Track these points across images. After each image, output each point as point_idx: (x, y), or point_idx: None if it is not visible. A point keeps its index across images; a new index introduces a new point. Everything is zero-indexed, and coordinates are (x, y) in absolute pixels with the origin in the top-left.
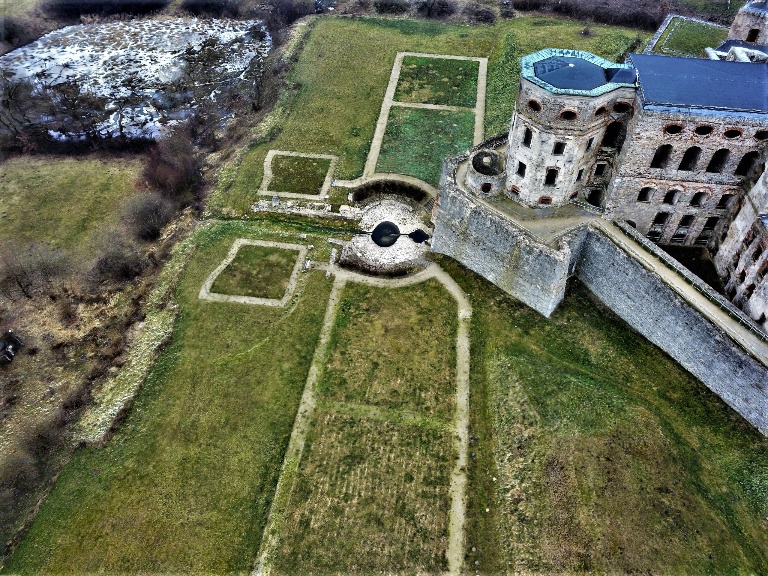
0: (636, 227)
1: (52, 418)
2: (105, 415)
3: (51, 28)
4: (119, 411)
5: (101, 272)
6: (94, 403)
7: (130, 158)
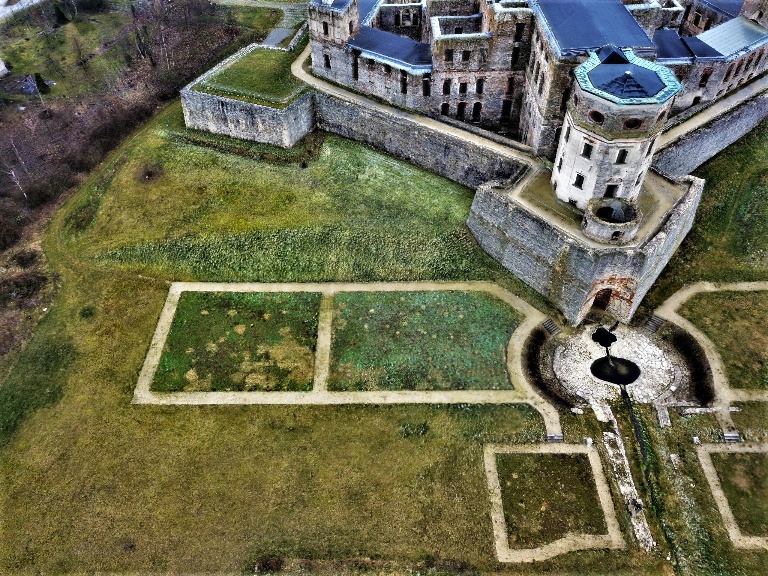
0: None
1: None
2: None
3: None
4: None
5: None
6: None
7: None
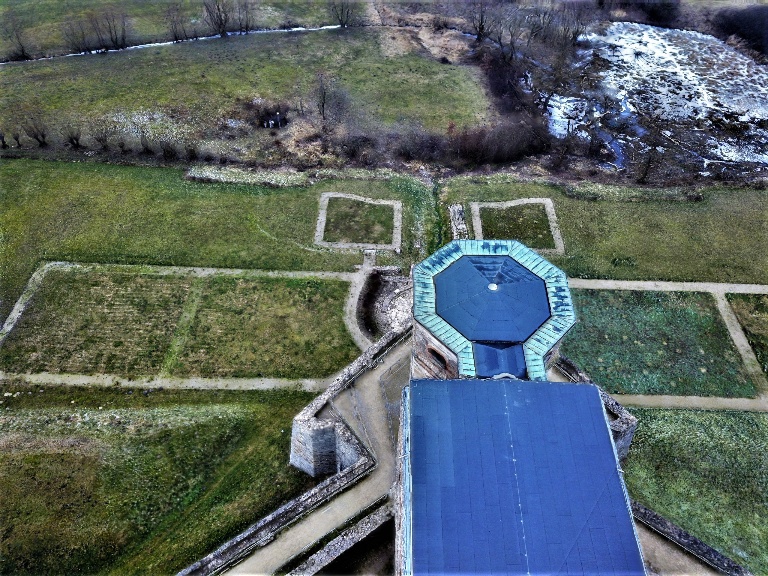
0: None
1: (215, 156)
2: (209, 174)
3: (699, 29)
4: None
5: (354, 141)
6: (221, 167)
7: (502, 119)
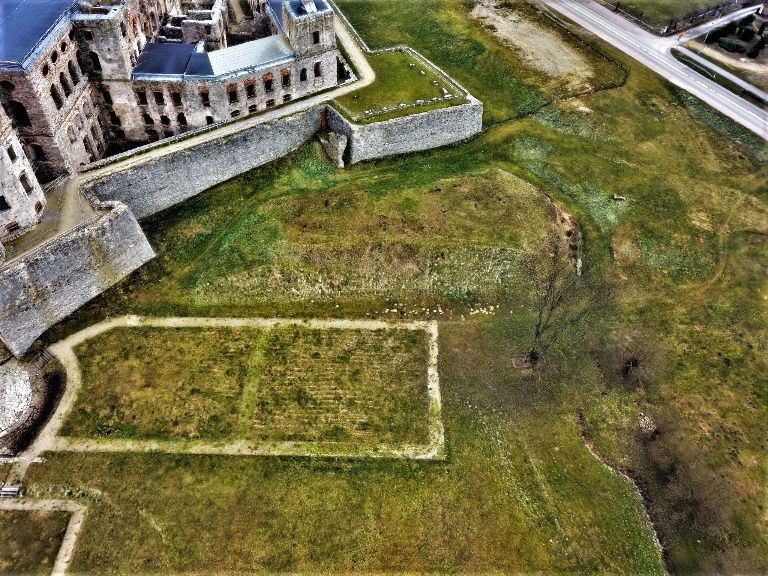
0: None
1: None
2: None
3: None
4: None
5: None
6: None
7: None
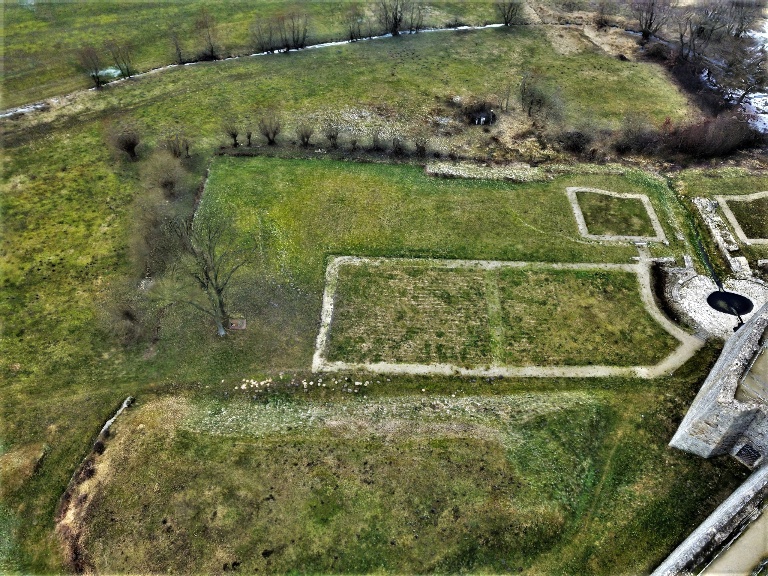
0: None
1: (441, 153)
2: (447, 170)
3: None
4: (451, 173)
5: (569, 137)
6: (455, 164)
7: (705, 115)
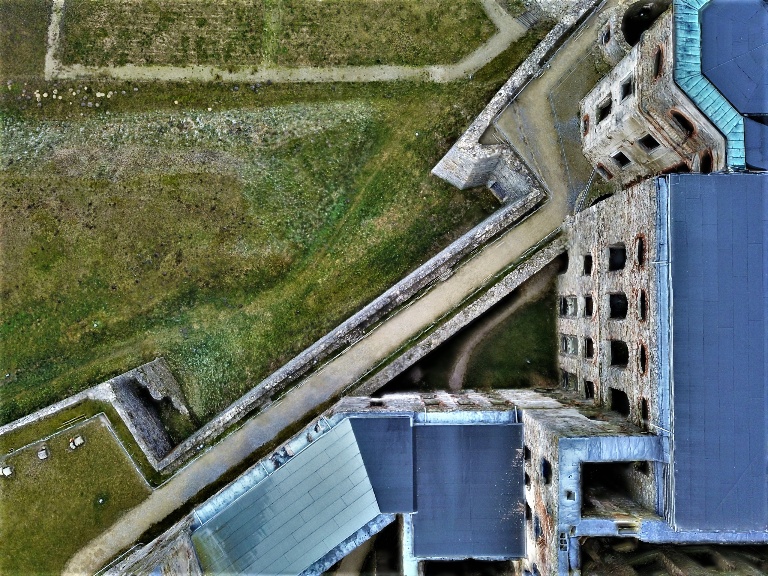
0: (566, 274)
1: None
2: None
3: None
4: None
5: None
6: None
7: None
